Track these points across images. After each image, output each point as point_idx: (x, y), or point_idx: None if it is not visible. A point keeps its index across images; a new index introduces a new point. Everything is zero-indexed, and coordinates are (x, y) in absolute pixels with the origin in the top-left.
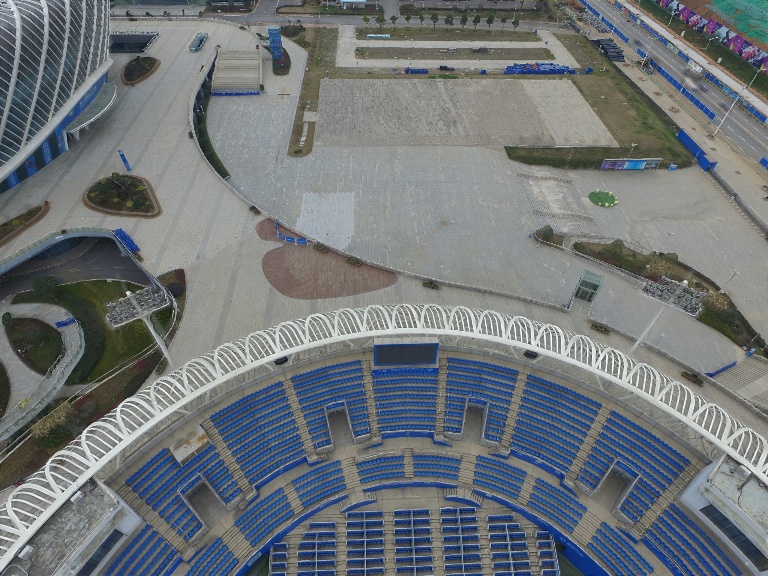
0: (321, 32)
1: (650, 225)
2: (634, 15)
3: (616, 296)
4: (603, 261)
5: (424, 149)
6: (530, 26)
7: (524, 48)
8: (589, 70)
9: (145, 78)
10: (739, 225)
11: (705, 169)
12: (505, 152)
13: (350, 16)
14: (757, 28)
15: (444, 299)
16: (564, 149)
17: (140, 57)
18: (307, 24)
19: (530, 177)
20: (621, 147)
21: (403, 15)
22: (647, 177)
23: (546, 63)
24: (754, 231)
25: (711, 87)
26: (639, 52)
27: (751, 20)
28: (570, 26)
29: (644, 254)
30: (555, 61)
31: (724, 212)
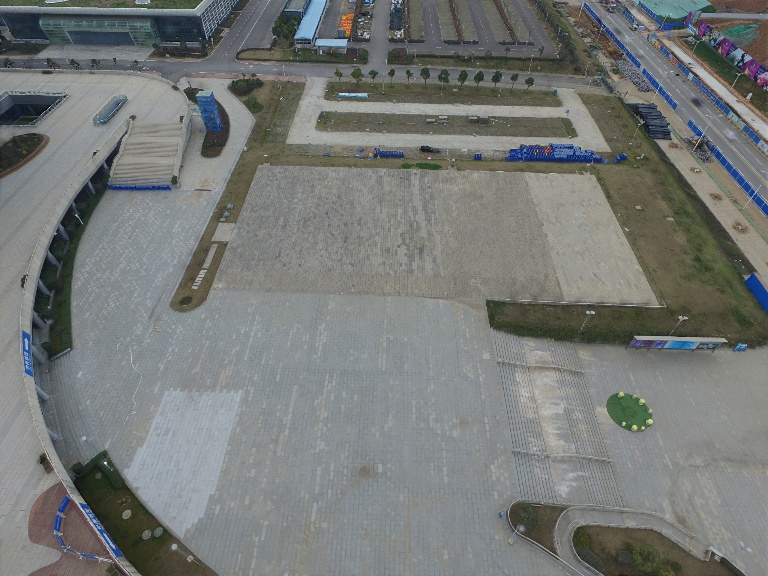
0: (282, 88)
1: (704, 478)
2: (685, 66)
3: None
4: None
5: (368, 302)
6: (549, 82)
7: (537, 117)
8: (621, 157)
9: (15, 169)
10: None
11: None
12: (486, 312)
13: (325, 64)
14: None
15: None
16: (575, 308)
17: (19, 136)
18: (268, 76)
19: (518, 365)
20: (661, 307)
21: (390, 64)
22: (700, 365)
23: (564, 145)
24: None
25: None
26: (691, 125)
27: None
28: (601, 82)
29: (694, 554)
30: (576, 140)
31: None
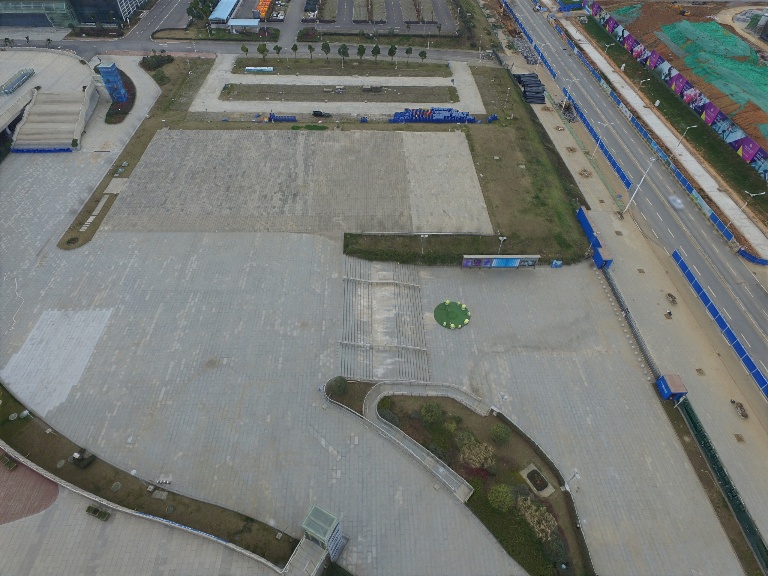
0: (192, 63)
1: (502, 360)
2: (573, 42)
3: (404, 504)
4: (410, 432)
5: (239, 237)
6: (446, 56)
7: (427, 86)
8: (493, 118)
9: None
10: (622, 360)
11: (599, 267)
12: (342, 242)
13: (236, 42)
14: (705, 64)
15: (106, 542)
16: (421, 237)
17: None
18: (180, 53)
19: (361, 282)
20: (495, 234)
21: (299, 41)
22: (521, 278)
23: (443, 108)
24: (640, 371)
25: (639, 140)
26: (564, 91)
27: (701, 53)
28: (494, 56)
29: (478, 412)
30: (457, 104)
31: (607, 338)
